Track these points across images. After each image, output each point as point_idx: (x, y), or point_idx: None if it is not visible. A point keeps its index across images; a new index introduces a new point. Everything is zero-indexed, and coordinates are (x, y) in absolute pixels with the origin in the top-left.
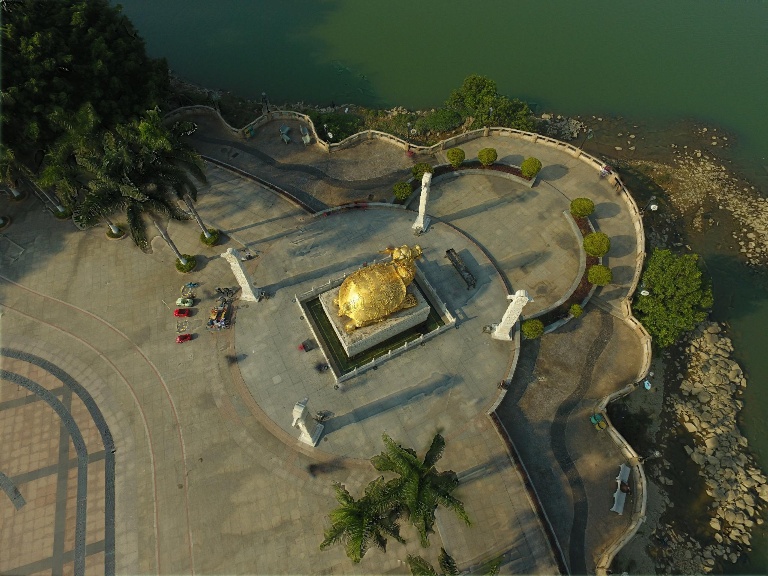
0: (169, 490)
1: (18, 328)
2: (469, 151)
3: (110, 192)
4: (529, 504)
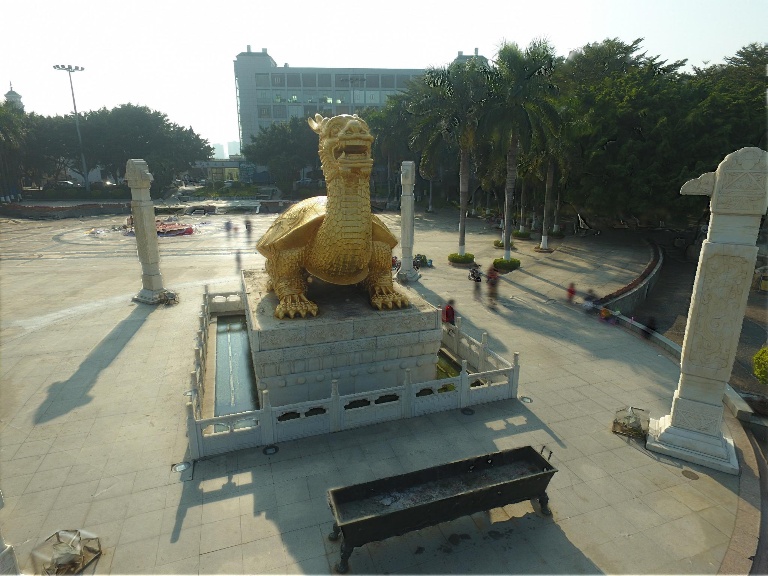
0: None
1: None
2: None
3: (444, 94)
4: None
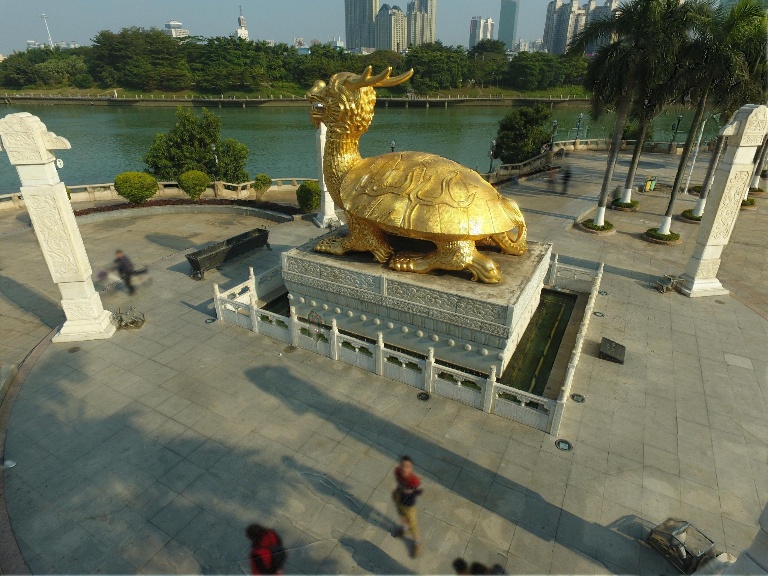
0: None
1: None
2: None
3: None
4: None
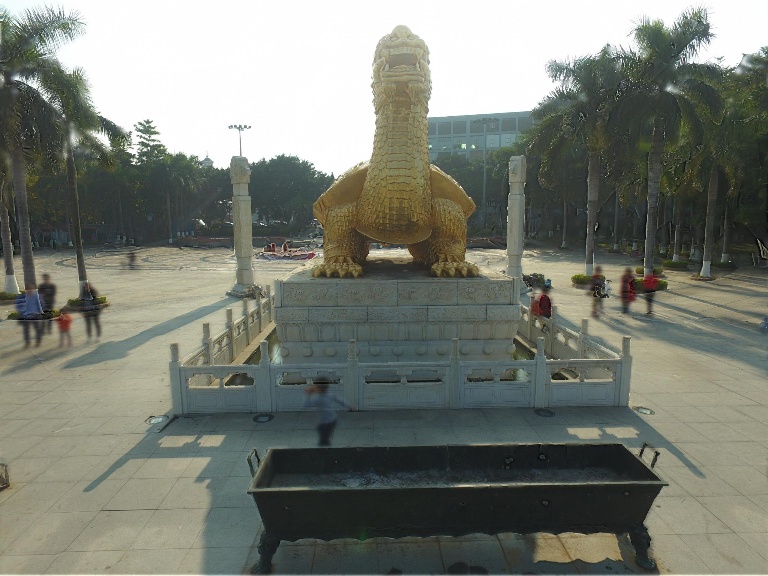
0: None
1: None
2: None
3: None
4: None
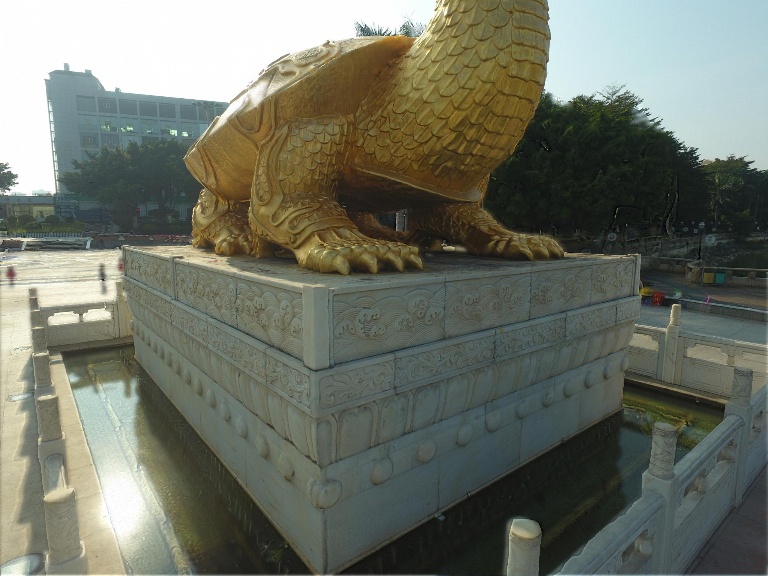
0: None
1: None
2: None
3: None
4: None
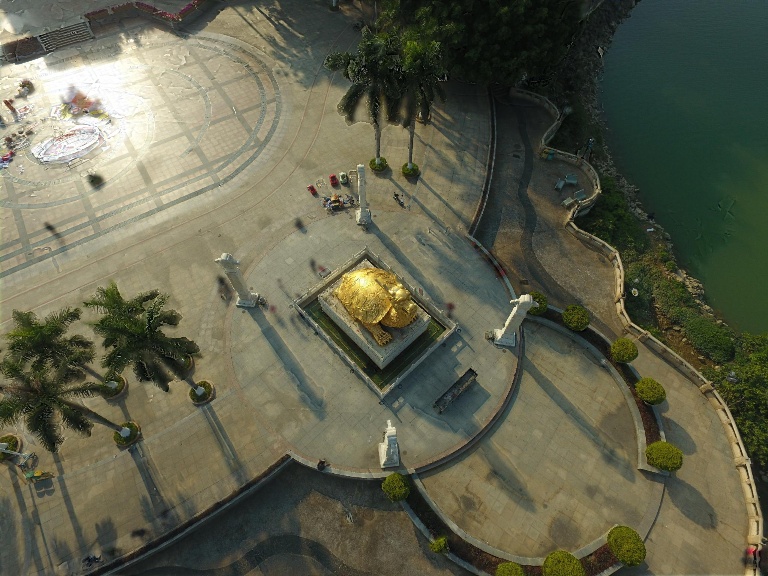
0: (197, 225)
1: (298, 102)
2: (659, 373)
3: None
4: (202, 510)
